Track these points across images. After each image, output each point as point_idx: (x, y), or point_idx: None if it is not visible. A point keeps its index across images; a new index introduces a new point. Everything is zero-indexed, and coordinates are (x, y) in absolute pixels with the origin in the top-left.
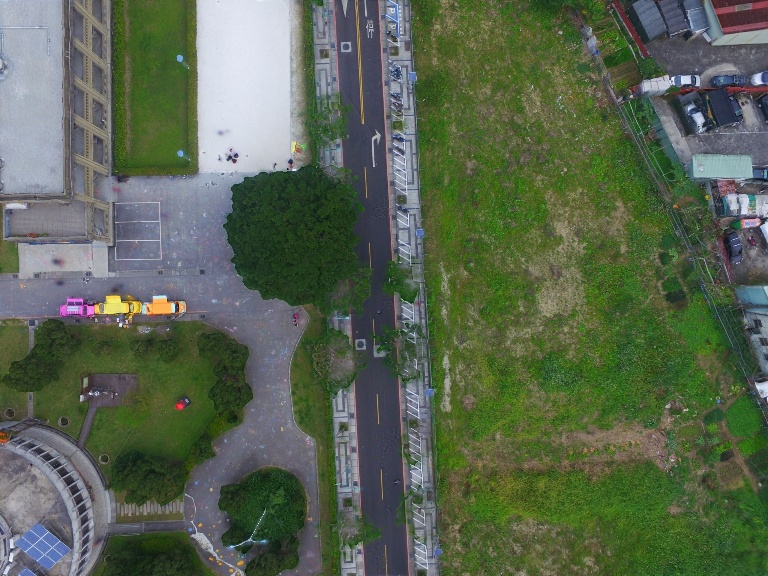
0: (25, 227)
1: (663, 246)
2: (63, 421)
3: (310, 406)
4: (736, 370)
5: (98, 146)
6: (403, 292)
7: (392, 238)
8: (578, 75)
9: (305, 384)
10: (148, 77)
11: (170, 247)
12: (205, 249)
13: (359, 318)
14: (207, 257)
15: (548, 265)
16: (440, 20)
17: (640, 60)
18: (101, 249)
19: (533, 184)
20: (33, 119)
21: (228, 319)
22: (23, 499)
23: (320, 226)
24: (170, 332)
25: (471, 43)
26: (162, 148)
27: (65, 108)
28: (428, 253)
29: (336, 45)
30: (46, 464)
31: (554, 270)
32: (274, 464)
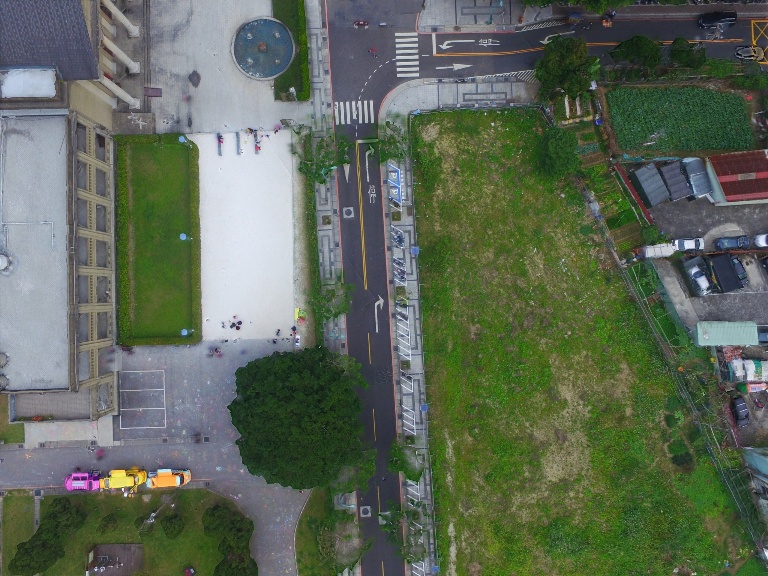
0: (30, 408)
1: (669, 409)
2: None
3: (315, 574)
4: (744, 533)
5: (102, 316)
6: (408, 474)
7: (396, 403)
8: (581, 237)
9: (310, 552)
10: (152, 245)
11: (174, 415)
12: (209, 417)
13: None
14: (211, 424)
15: (553, 429)
16: (442, 185)
17: (643, 221)
18: (106, 418)
19: (537, 348)
20: (38, 314)
21: (233, 486)
22: None
23: (324, 417)
24: (175, 501)
25: (473, 207)
26: (166, 316)
27: (70, 304)
28: (432, 419)
29: (338, 211)
30: None
31: (559, 435)
32: None
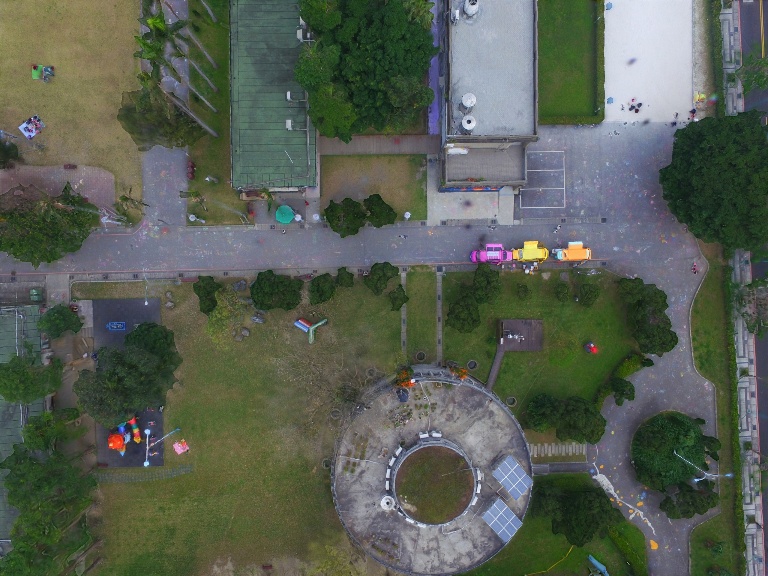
0: (461, 172)
1: None
2: (470, 365)
3: (711, 352)
4: None
5: None
6: None
7: None
8: None
9: (706, 330)
10: (553, 27)
11: (574, 195)
12: (607, 197)
13: (759, 266)
14: (609, 205)
15: None
16: None
17: None
18: (508, 197)
19: None
20: (501, 62)
21: (629, 266)
22: (481, 434)
23: None
24: (574, 279)
25: None
26: (567, 98)
27: (537, 51)
28: None
29: None
30: (499, 401)
31: None
32: (674, 408)
